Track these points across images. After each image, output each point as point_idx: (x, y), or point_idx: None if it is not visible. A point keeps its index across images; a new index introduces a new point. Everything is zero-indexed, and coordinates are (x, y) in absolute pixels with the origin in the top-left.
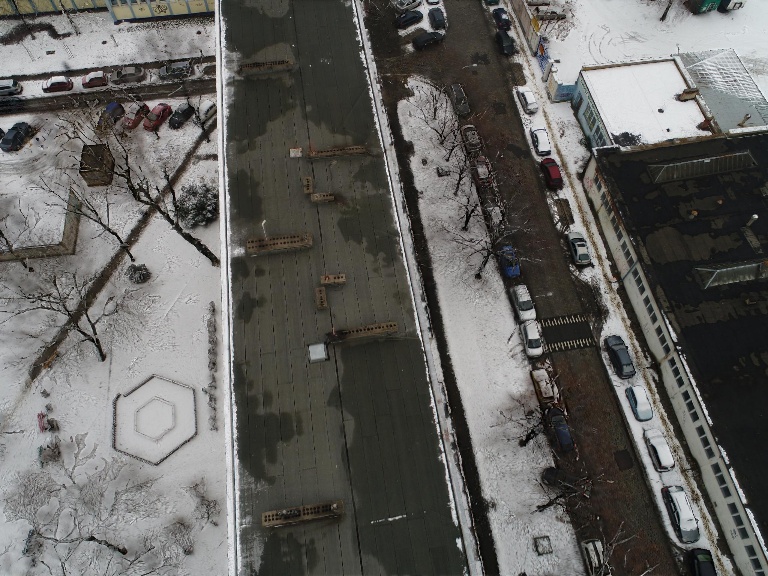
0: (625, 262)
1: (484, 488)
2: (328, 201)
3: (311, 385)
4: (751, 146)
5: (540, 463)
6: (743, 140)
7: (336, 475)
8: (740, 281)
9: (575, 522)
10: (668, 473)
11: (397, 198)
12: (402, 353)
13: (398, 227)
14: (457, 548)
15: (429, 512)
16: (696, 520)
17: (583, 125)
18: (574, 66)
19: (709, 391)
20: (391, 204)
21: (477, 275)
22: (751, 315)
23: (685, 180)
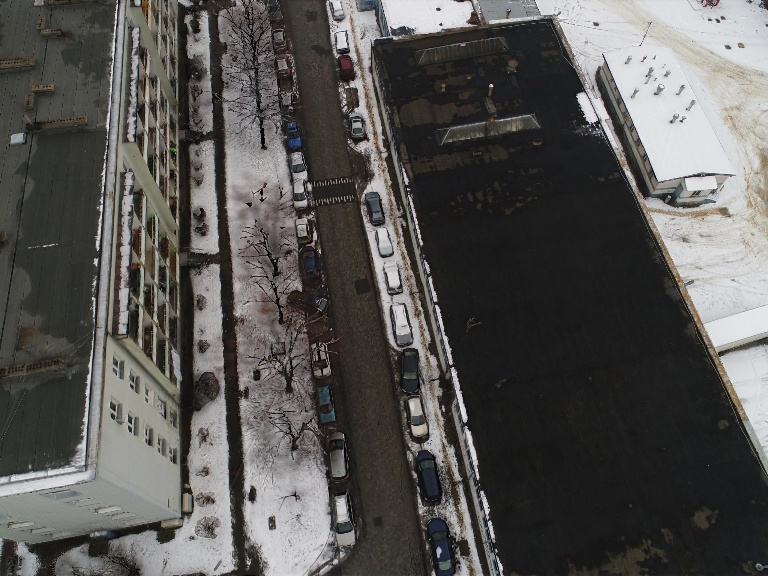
0: (389, 132)
1: (236, 308)
2: (57, 36)
3: (6, 161)
4: (507, 35)
5: (289, 289)
6: (501, 30)
7: (8, 218)
8: (472, 138)
9: (311, 333)
10: (398, 295)
11: (120, 36)
12: (89, 140)
13: (113, 55)
14: (93, 264)
15: (78, 242)
16: (410, 327)
17: (381, 28)
18: None
19: (426, 221)
20: (112, 39)
21: (262, 146)
22: (475, 164)
23: (445, 62)
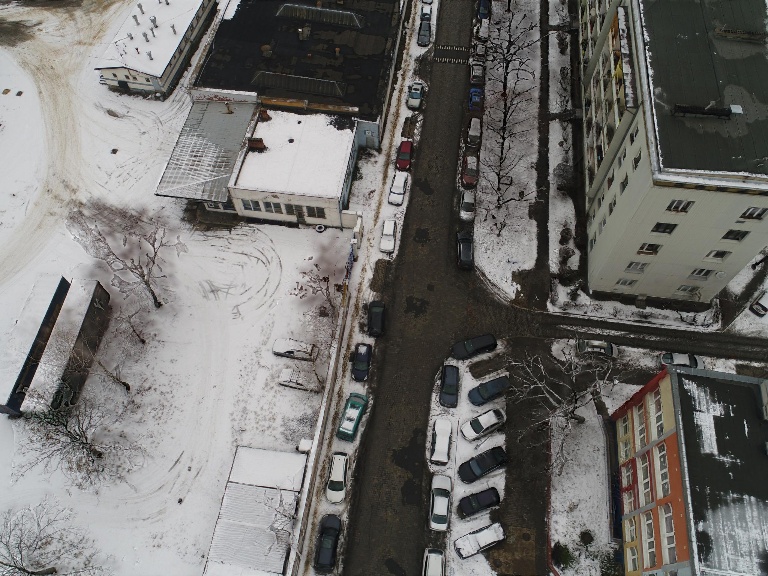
0: None
1: (539, 0)
2: None
3: None
4: (246, 86)
5: (501, 3)
6: None
7: None
8: None
9: None
10: None
11: None
12: None
13: None
14: None
15: None
16: None
17: None
18: (311, 267)
19: None
20: None
21: None
22: None
23: None
